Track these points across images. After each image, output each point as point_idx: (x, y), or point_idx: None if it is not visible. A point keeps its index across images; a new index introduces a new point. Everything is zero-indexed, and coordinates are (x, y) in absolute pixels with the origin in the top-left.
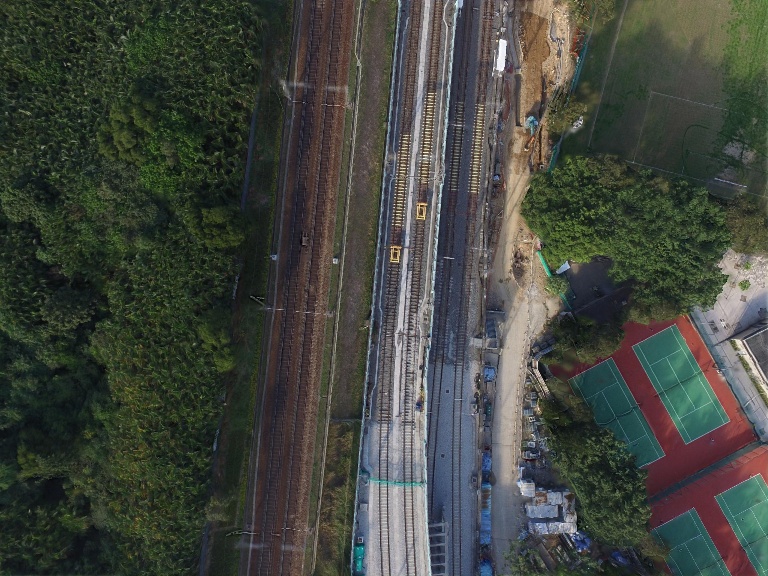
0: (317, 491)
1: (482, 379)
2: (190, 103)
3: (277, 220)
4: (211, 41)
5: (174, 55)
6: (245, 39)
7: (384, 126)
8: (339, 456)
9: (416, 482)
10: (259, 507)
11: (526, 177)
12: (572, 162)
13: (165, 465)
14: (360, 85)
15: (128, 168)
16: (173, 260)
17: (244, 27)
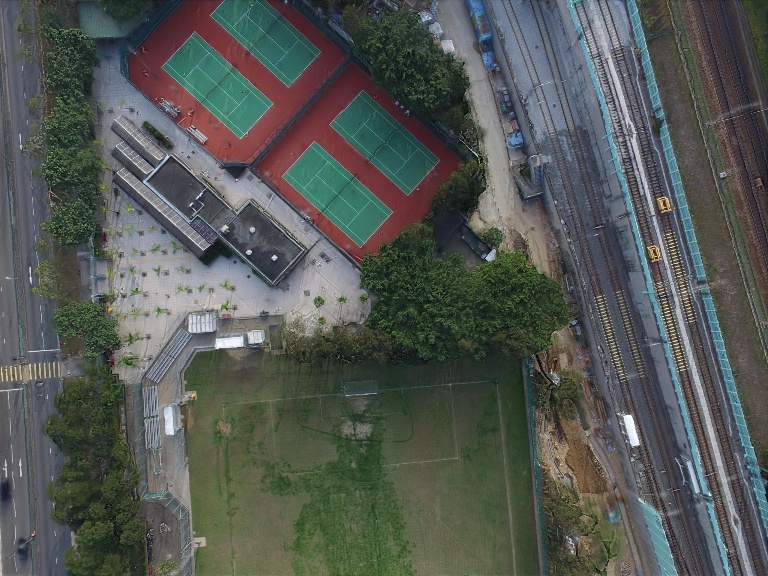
0: None
1: None
2: None
3: None
4: None
5: None
6: None
7: None
8: (651, 2)
9: (572, 6)
10: None
11: None
12: (548, 343)
13: None
14: (763, 348)
15: None
16: None
17: None
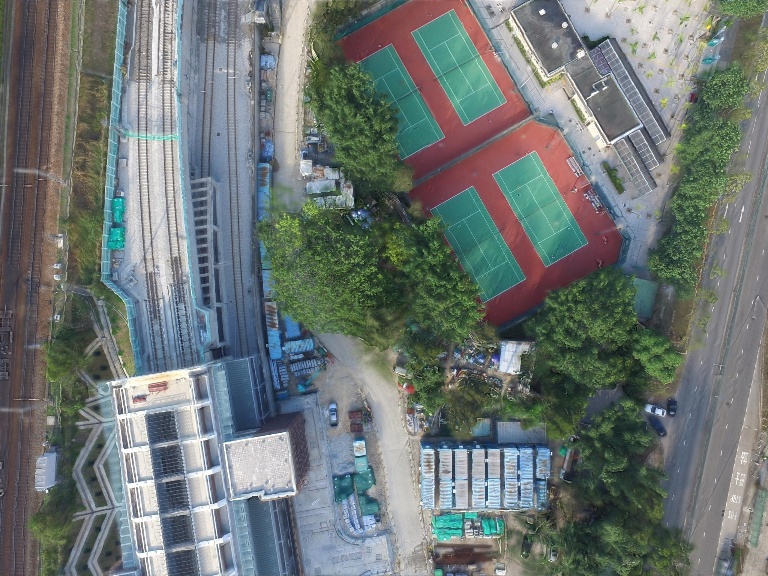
0: (71, 144)
1: (252, 53)
2: None
3: None
4: None
5: None
6: None
7: None
8: (94, 111)
9: (175, 137)
10: (10, 159)
11: None
12: None
13: None
14: None
15: None
16: None
17: None
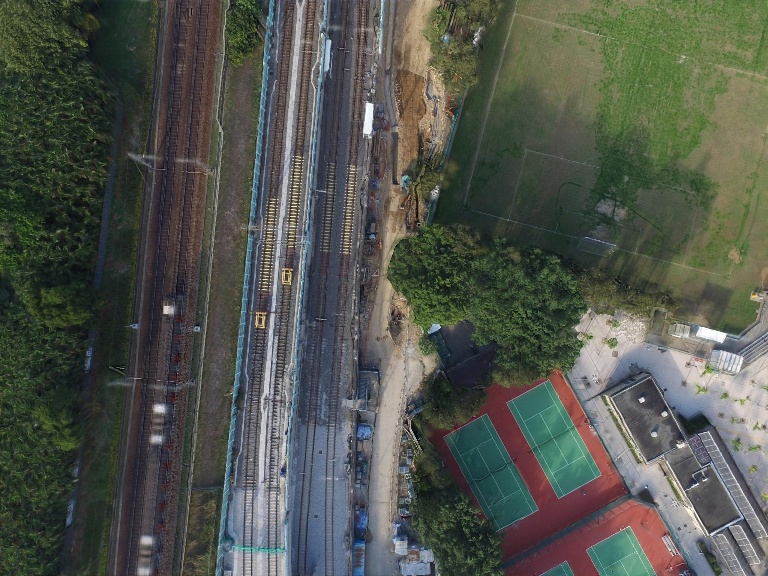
0: (179, 560)
1: (353, 440)
2: (31, 181)
3: (138, 288)
4: (51, 118)
5: (14, 132)
6: (88, 114)
7: (250, 190)
8: (202, 524)
9: (280, 548)
10: None
11: (402, 235)
12: (430, 230)
13: (8, 546)
14: (222, 151)
15: None
16: (13, 341)
17: (88, 102)
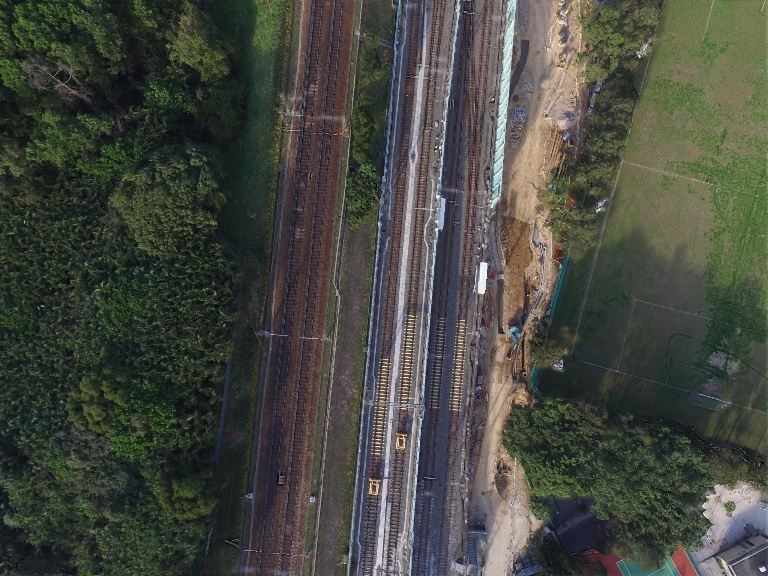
0: None
1: None
2: (162, 368)
3: (253, 456)
4: (184, 304)
5: (146, 319)
6: (219, 298)
7: (363, 351)
8: None
9: None
10: None
11: (509, 386)
12: (553, 404)
13: None
14: (339, 316)
15: (98, 439)
16: (143, 534)
17: (219, 285)
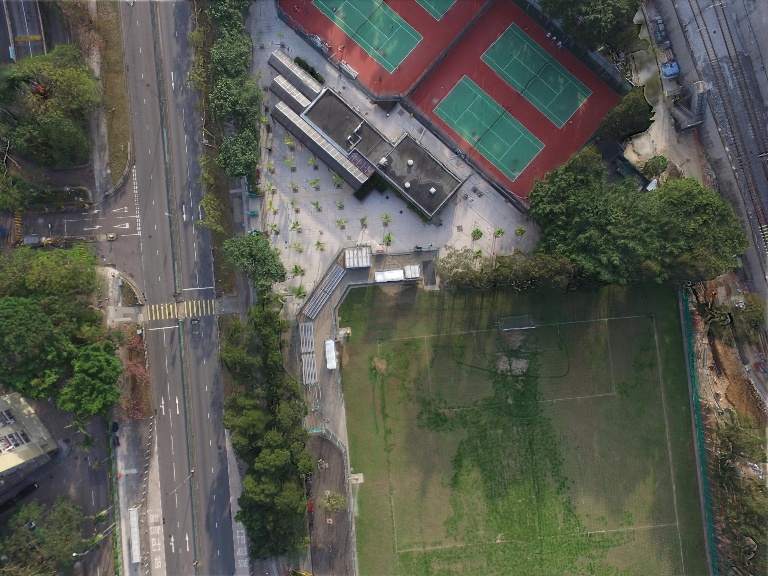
0: None
1: None
2: None
3: None
4: None
5: None
6: None
7: None
8: None
9: None
10: None
11: None
12: None
13: None
14: None
15: None
16: None
17: None
